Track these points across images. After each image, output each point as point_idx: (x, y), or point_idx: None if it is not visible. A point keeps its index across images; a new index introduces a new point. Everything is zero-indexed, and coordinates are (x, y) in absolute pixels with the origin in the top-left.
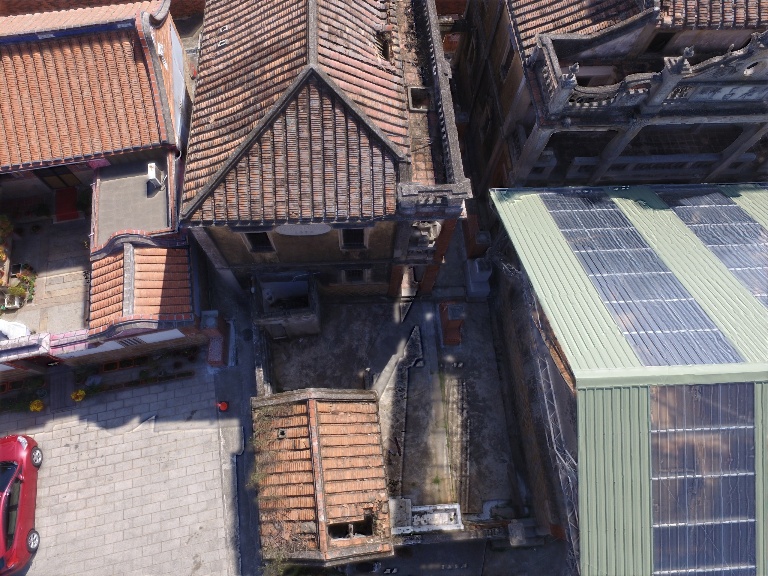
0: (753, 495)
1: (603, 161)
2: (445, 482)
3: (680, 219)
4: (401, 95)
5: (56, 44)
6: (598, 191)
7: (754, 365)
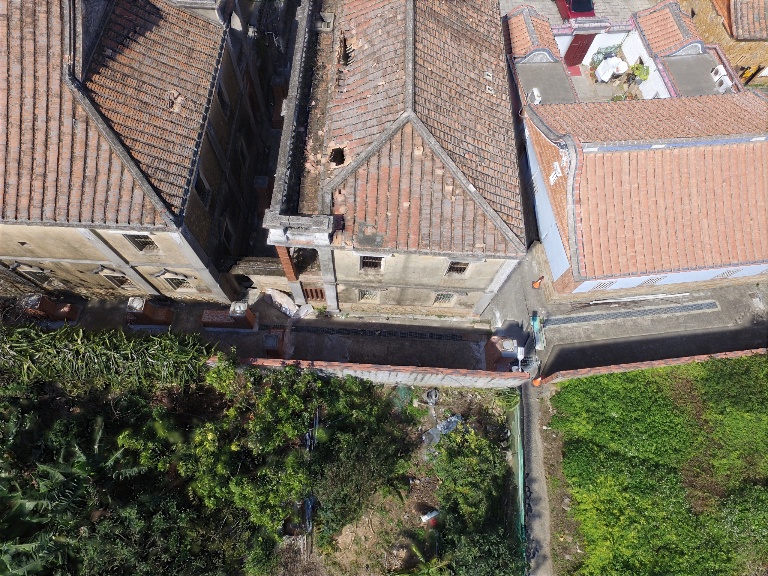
0: None
1: None
2: None
3: None
4: (341, 8)
5: None
6: None
7: None
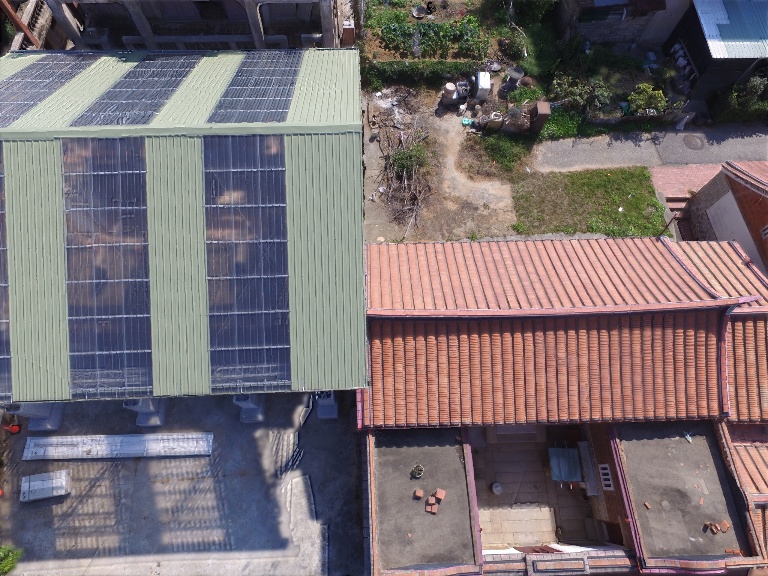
0: (5, 229)
1: (143, 38)
2: None
3: (133, 67)
4: None
5: None
6: (102, 53)
7: (6, 128)
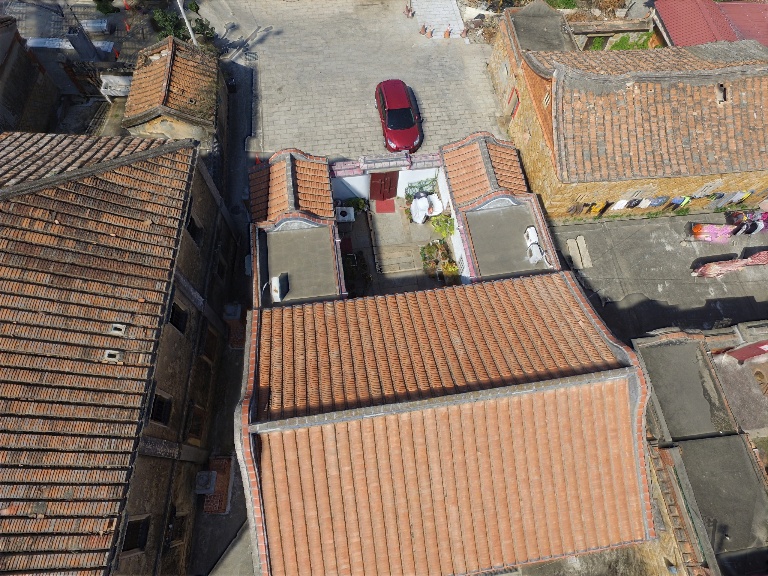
0: None
1: None
2: (111, 115)
3: None
4: None
5: (364, 405)
6: None
7: None
